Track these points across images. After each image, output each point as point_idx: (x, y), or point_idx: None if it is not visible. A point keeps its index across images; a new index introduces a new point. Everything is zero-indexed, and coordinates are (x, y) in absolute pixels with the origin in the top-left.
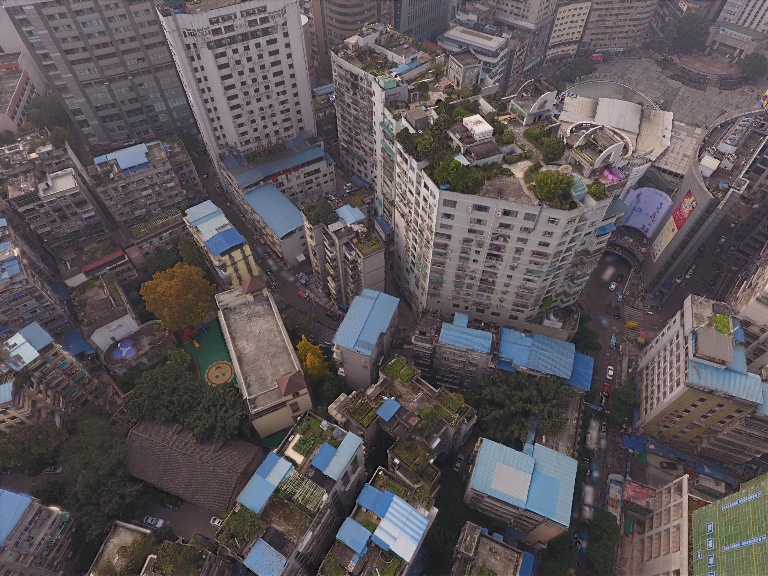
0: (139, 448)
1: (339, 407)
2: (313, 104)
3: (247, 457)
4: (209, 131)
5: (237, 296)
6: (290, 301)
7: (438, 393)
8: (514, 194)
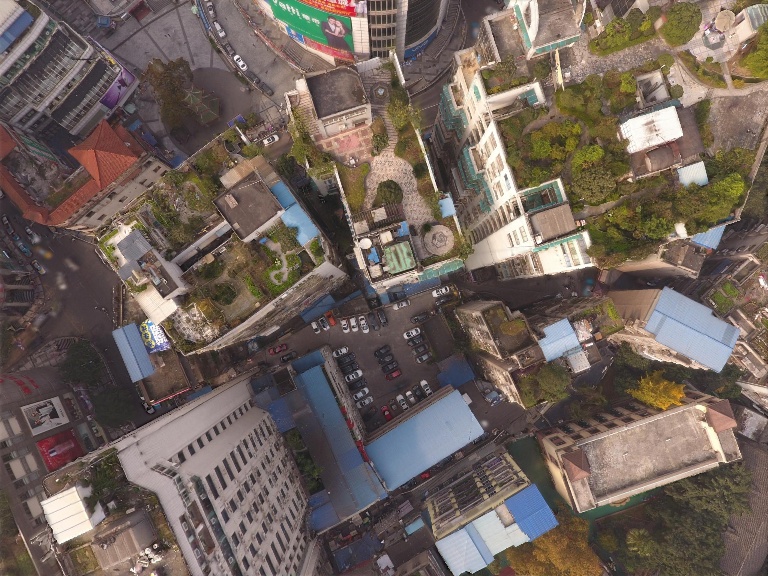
0: (749, 567)
1: (758, 366)
2: (168, 381)
3: (763, 457)
4: (303, 568)
5: (584, 485)
6: (521, 413)
7: (759, 260)
8: (747, 112)
